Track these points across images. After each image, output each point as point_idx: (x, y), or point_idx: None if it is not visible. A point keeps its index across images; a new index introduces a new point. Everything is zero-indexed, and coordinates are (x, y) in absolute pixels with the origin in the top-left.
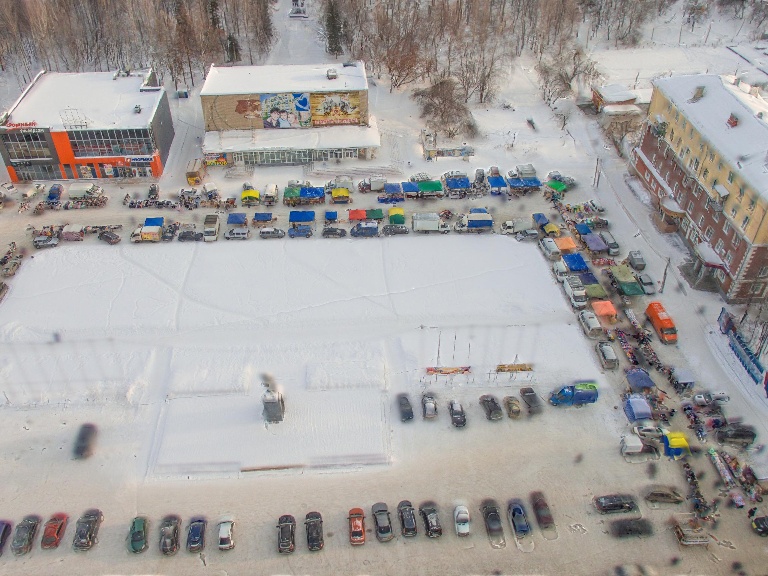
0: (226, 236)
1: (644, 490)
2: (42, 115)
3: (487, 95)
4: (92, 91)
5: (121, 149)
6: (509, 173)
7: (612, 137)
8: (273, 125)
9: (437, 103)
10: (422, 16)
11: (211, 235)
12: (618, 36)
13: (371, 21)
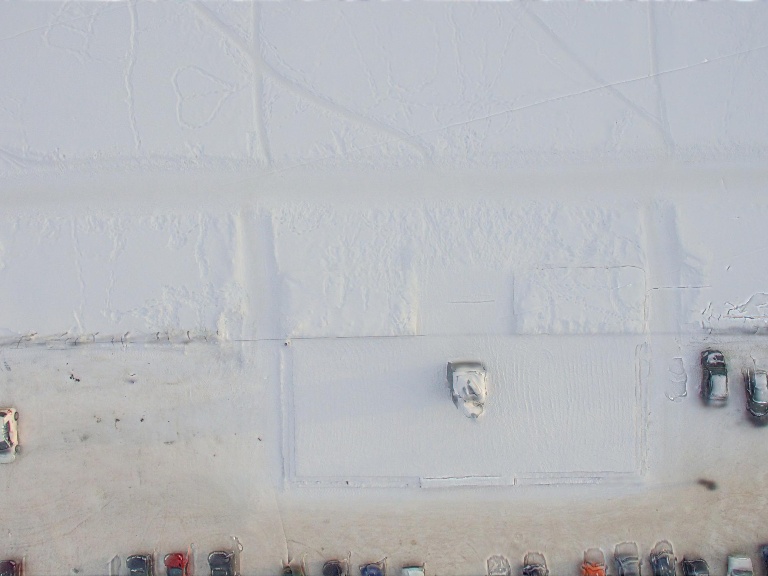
0: None
1: None
2: None
3: None
4: None
5: None
6: None
7: None
8: None
9: None
10: None
11: None
12: None
13: None
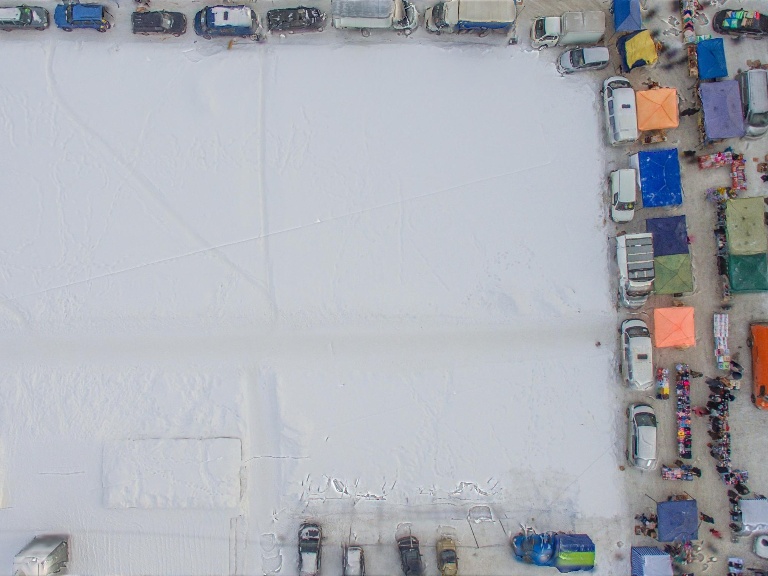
0: None
1: None
2: None
3: None
4: None
5: None
6: None
7: None
8: None
9: None
10: None
11: None
12: None
13: None
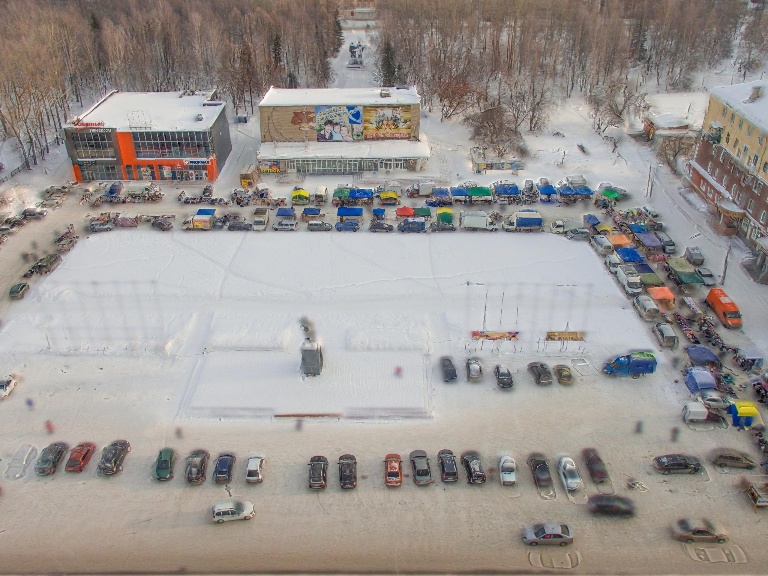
0: (274, 227)
1: (711, 454)
2: (111, 119)
3: (537, 123)
4: (159, 105)
5: (181, 151)
6: (559, 183)
7: (665, 154)
8: (326, 138)
9: (487, 126)
10: (473, 59)
11: (260, 224)
12: (668, 81)
13: (424, 63)
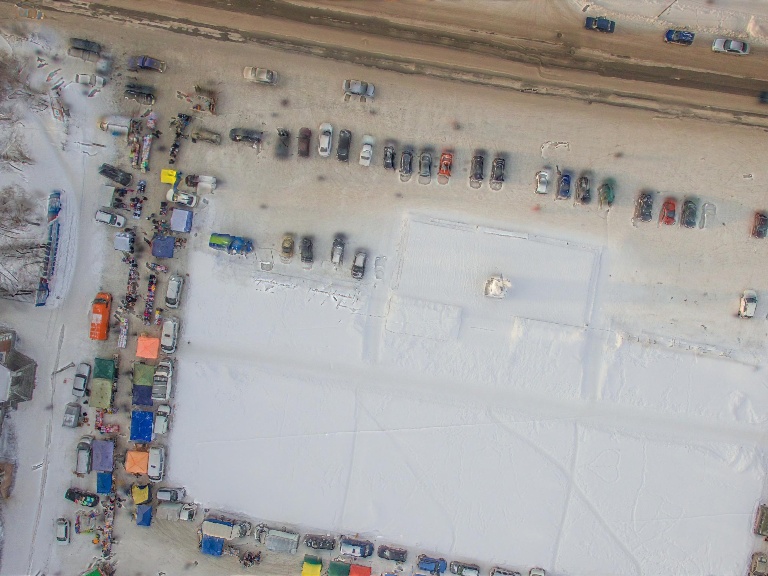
0: (520, 575)
1: None
2: None
3: None
4: None
5: None
6: None
7: None
8: None
9: None
10: None
11: None
12: None
13: None
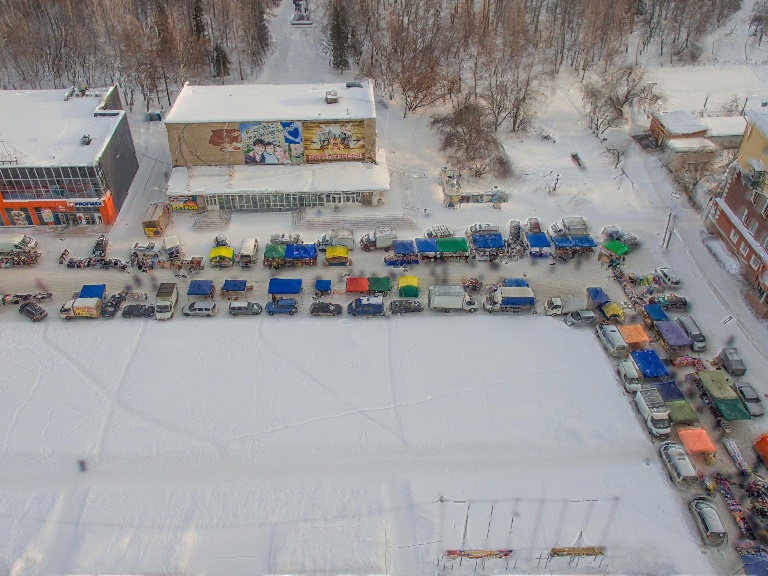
0: (184, 312)
1: None
2: None
3: (521, 122)
4: (35, 115)
5: (61, 191)
6: (553, 227)
7: (683, 182)
8: (256, 160)
9: (461, 133)
10: (443, 25)
11: (164, 311)
12: (673, 51)
13: (383, 30)
